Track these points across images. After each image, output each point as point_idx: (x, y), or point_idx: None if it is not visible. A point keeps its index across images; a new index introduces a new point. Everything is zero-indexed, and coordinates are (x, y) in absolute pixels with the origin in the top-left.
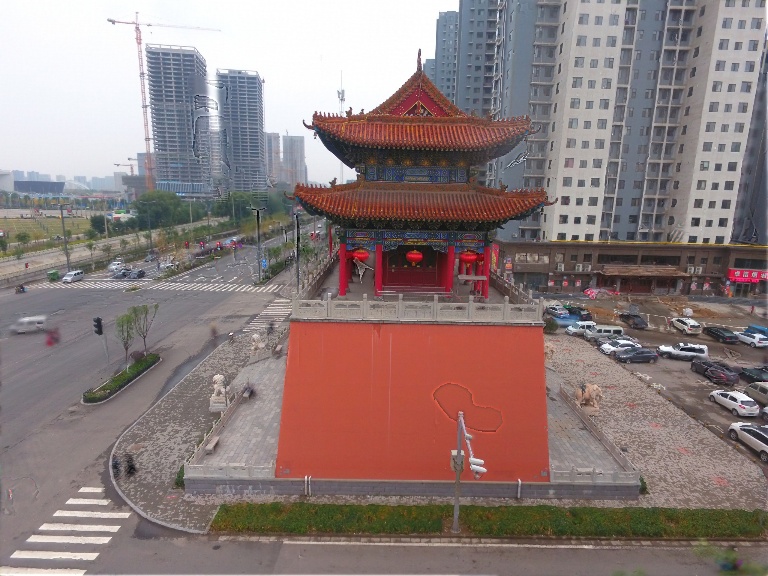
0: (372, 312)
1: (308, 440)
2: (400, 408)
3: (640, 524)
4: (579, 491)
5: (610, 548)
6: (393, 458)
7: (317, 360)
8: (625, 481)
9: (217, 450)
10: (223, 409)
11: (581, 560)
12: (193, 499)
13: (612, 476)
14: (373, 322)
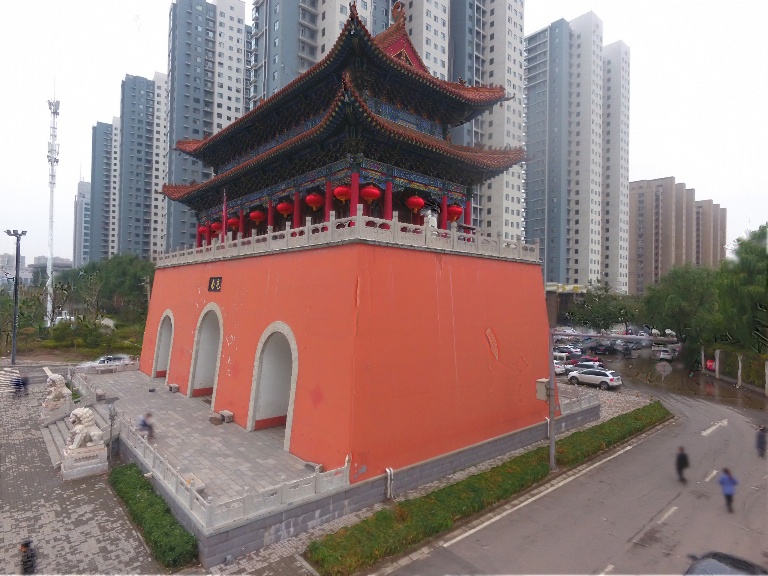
0: (432, 240)
1: (383, 414)
2: (464, 355)
3: (632, 424)
4: (576, 419)
5: (638, 444)
6: (462, 419)
7: (388, 298)
8: (593, 402)
9: (204, 491)
10: (94, 469)
11: (641, 455)
12: (235, 568)
13: (588, 400)
14: (436, 251)
